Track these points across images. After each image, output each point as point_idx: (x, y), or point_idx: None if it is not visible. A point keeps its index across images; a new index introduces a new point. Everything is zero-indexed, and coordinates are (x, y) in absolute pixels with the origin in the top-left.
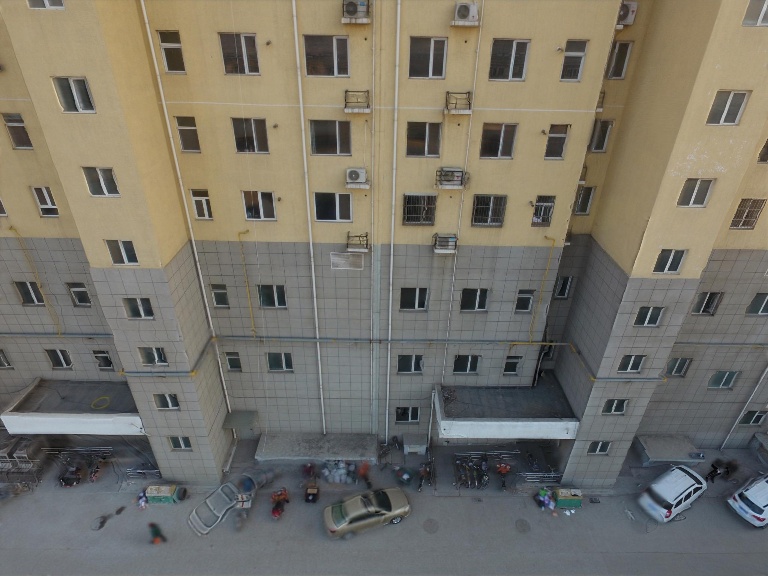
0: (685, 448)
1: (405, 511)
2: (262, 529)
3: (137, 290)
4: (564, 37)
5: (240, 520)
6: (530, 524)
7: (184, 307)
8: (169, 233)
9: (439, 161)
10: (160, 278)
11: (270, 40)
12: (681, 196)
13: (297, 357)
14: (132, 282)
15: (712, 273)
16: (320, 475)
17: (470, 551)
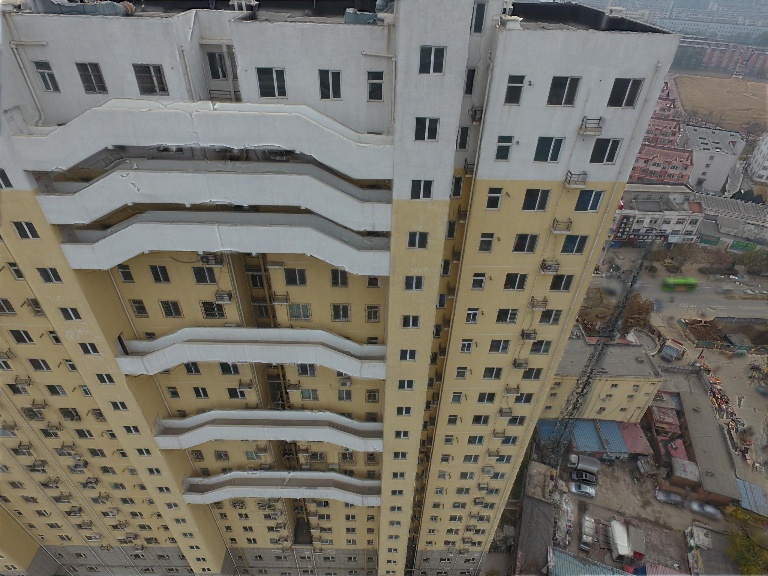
0: None
1: None
2: None
3: (19, 574)
4: (151, 512)
5: None
6: None
7: (40, 571)
8: (29, 554)
9: (126, 531)
10: (26, 573)
11: (51, 512)
12: (197, 559)
13: (100, 568)
14: (16, 573)
15: (252, 552)
16: None
17: None
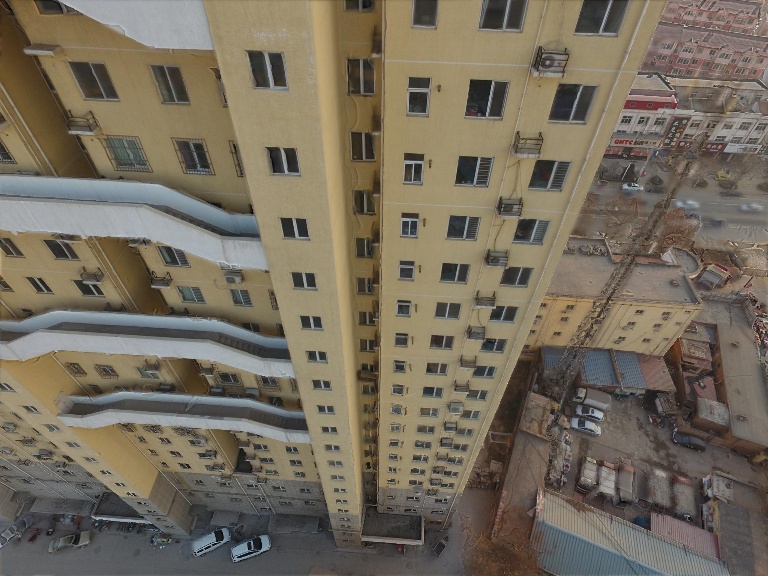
0: (232, 519)
1: (86, 544)
2: (24, 547)
3: None
4: None
5: (15, 543)
6: (141, 552)
7: None
8: None
9: None
10: None
11: None
12: None
13: None
14: None
15: None
16: (59, 520)
17: (107, 563)
